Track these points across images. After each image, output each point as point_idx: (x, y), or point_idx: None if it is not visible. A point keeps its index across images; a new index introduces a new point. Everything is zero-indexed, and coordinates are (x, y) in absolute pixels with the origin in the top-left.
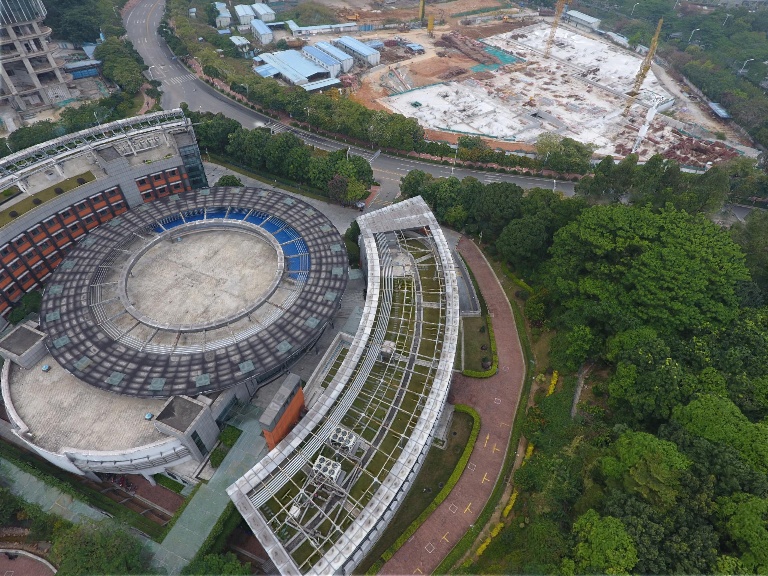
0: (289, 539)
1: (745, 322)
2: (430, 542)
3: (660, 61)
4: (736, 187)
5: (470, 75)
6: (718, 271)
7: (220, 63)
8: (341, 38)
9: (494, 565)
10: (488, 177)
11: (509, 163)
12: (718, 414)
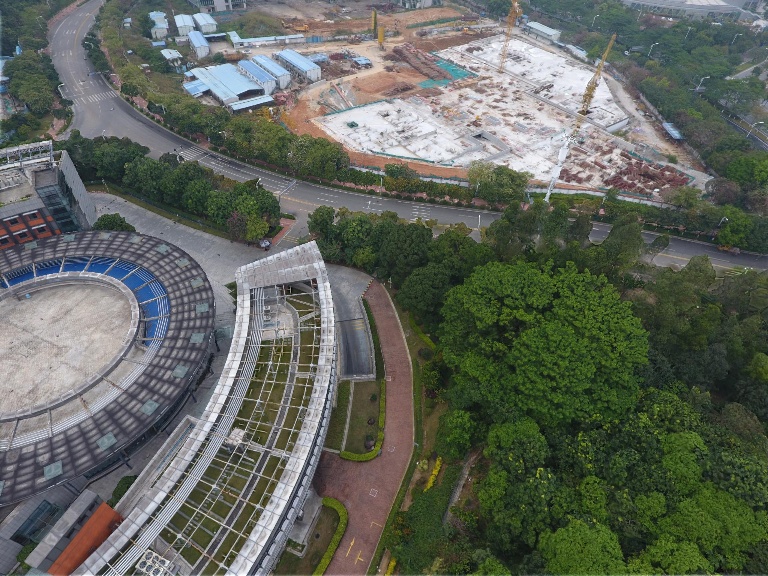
0: None
1: (638, 416)
2: None
3: (618, 76)
4: (677, 221)
5: (416, 92)
6: (609, 354)
7: (142, 80)
8: (282, 51)
9: None
10: (416, 208)
11: (437, 194)
12: (584, 552)
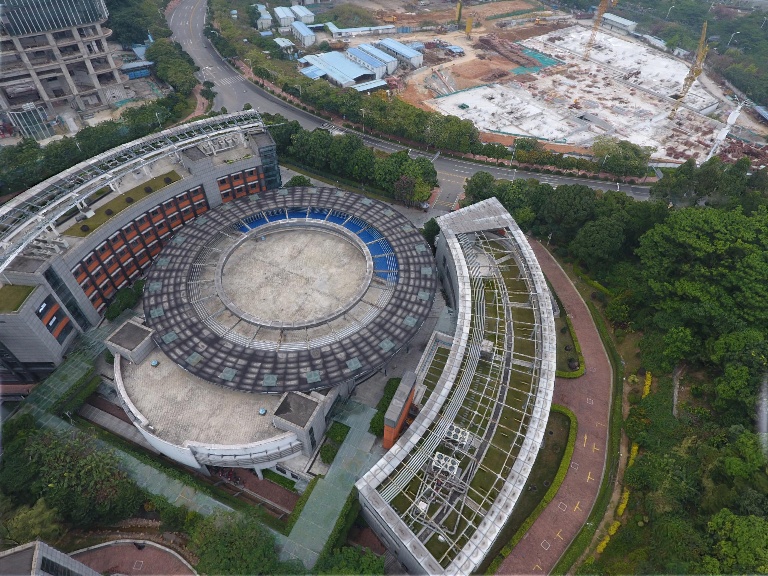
0: (416, 534)
1: None
2: (545, 539)
3: None
4: None
5: (512, 77)
6: None
7: (269, 64)
8: (383, 40)
9: (619, 562)
10: (545, 179)
11: (567, 165)
12: None
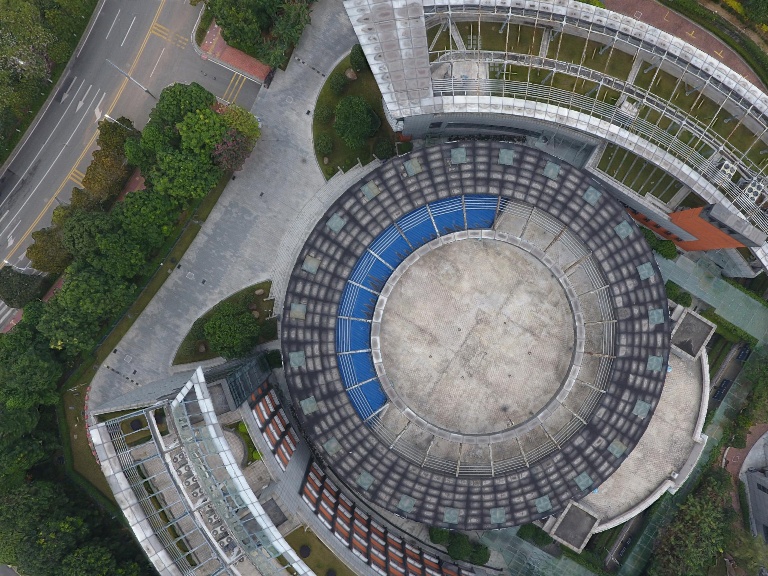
0: None
1: None
2: None
3: None
4: None
5: None
6: None
7: None
8: None
9: None
10: None
11: None
12: None
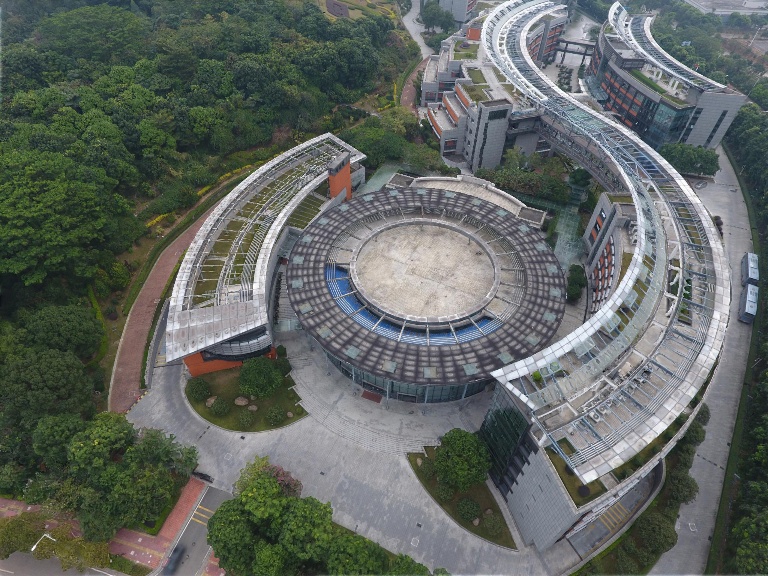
0: None
1: None
2: None
3: None
4: None
5: None
6: None
7: None
8: None
9: (245, 158)
10: None
11: None
12: None
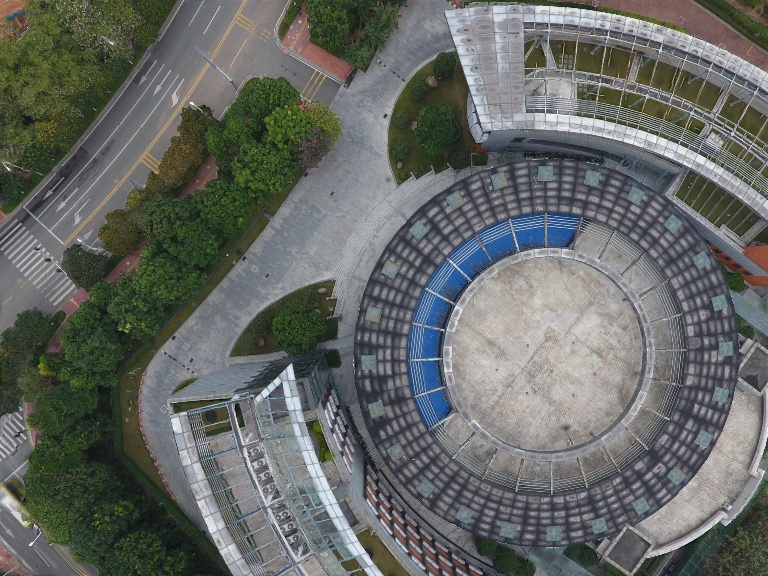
0: None
1: None
2: None
3: None
4: None
5: None
6: None
7: None
8: None
9: None
10: None
11: None
12: None
